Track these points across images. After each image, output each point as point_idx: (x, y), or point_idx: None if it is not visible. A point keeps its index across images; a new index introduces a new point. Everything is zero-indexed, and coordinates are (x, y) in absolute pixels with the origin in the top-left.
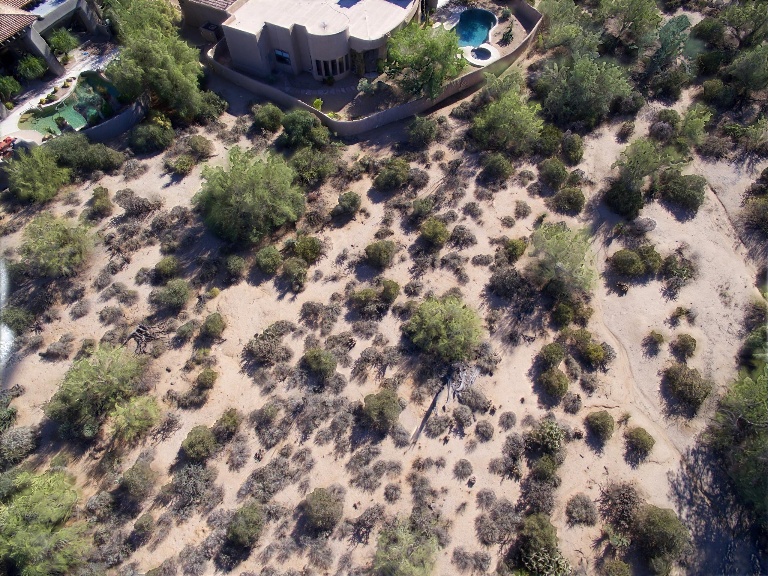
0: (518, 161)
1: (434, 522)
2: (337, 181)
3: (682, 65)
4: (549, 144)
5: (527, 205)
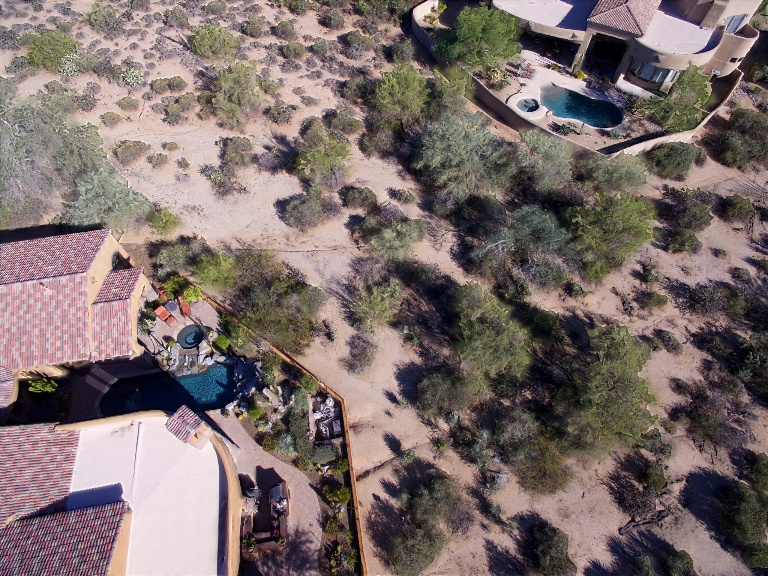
0: (369, 111)
1: (115, 32)
2: (363, 21)
3: (522, 279)
4: (377, 121)
5: (312, 101)
